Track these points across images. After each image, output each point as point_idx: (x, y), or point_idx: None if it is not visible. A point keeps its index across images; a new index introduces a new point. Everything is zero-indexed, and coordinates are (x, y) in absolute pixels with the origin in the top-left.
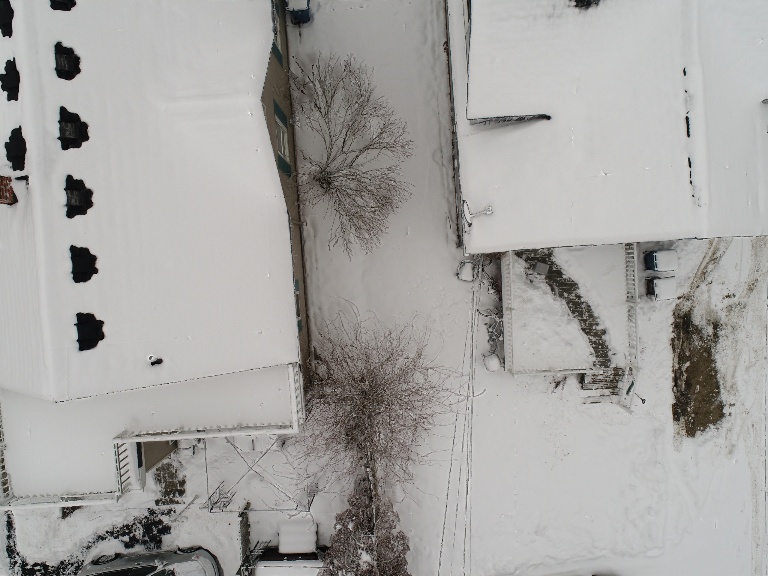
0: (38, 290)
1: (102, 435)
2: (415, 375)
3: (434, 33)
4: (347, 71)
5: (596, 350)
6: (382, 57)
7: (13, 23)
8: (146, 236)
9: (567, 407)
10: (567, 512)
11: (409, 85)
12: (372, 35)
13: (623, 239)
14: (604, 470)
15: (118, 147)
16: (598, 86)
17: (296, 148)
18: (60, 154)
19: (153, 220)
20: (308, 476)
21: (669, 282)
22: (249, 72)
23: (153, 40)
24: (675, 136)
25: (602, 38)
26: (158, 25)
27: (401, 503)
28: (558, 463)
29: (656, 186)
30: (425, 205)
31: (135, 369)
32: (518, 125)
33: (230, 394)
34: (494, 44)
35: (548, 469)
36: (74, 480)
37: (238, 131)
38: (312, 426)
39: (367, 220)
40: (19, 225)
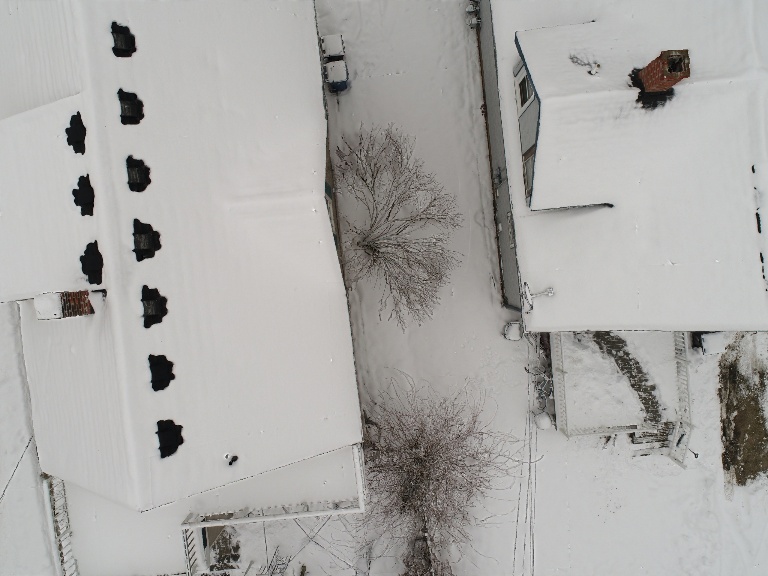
0: (120, 402)
1: (167, 518)
2: (468, 438)
3: (471, 96)
4: (389, 140)
5: (646, 406)
6: (420, 122)
7: (86, 141)
8: (217, 336)
9: (618, 461)
10: (621, 564)
11: (448, 148)
12: (409, 100)
13: (694, 328)
14: (657, 521)
15: (188, 252)
16: (662, 178)
17: (338, 214)
18: (135, 266)
19: (223, 320)
20: (367, 543)
21: (717, 337)
22: (310, 167)
23: (216, 142)
24: (745, 231)
25: (667, 135)
26: (220, 126)
27: (455, 561)
28: (611, 516)
29: (727, 279)
30: (469, 266)
31: (213, 469)
32: (578, 210)
33: (293, 473)
34: (561, 144)
35: (601, 522)
36: (141, 564)
37: (301, 226)
38: (369, 494)
39: (418, 291)
40: (95, 334)
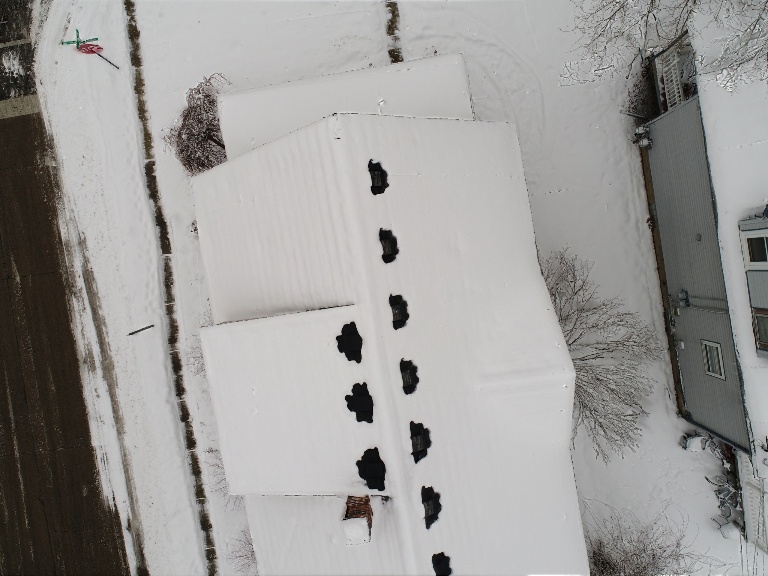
0: None
1: None
2: None
3: (637, 211)
4: None
5: None
6: (586, 238)
7: (364, 351)
8: (480, 520)
9: None
10: None
11: (616, 263)
12: (574, 217)
13: None
14: None
15: (452, 442)
16: None
17: None
18: (415, 469)
19: (483, 502)
20: None
21: None
22: (551, 339)
23: (463, 324)
24: None
25: None
26: (465, 308)
27: None
28: None
29: None
30: None
31: None
32: None
33: None
34: None
35: None
36: None
37: (547, 399)
38: None
39: (616, 421)
40: None
